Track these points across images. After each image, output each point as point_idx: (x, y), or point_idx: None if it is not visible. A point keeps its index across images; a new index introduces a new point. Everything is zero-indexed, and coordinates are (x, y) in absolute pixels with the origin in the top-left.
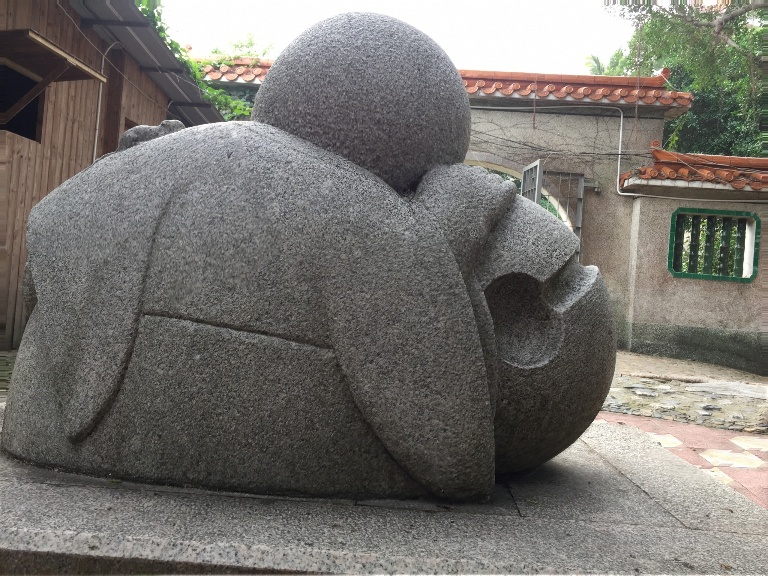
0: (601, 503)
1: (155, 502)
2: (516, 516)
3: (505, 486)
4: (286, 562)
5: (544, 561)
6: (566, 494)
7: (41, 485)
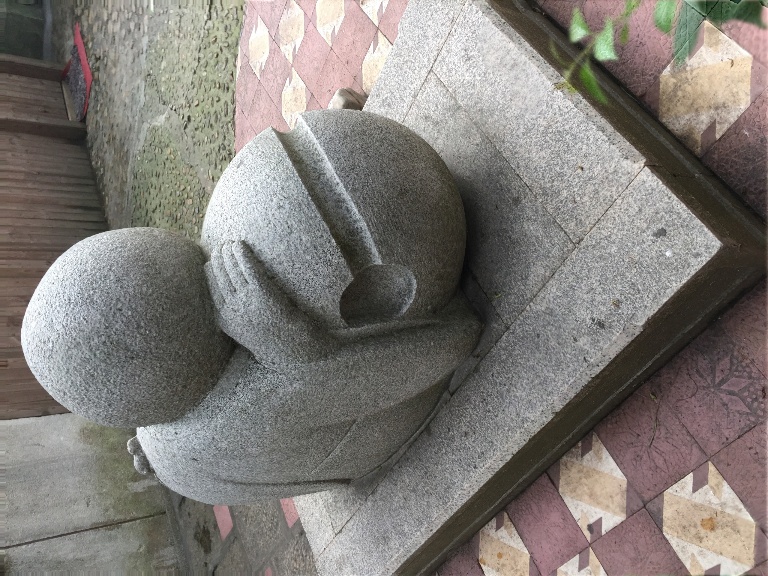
0: (522, 250)
1: (407, 476)
2: (506, 332)
3: (473, 278)
4: (480, 483)
5: (549, 392)
6: (501, 254)
7: (371, 498)
